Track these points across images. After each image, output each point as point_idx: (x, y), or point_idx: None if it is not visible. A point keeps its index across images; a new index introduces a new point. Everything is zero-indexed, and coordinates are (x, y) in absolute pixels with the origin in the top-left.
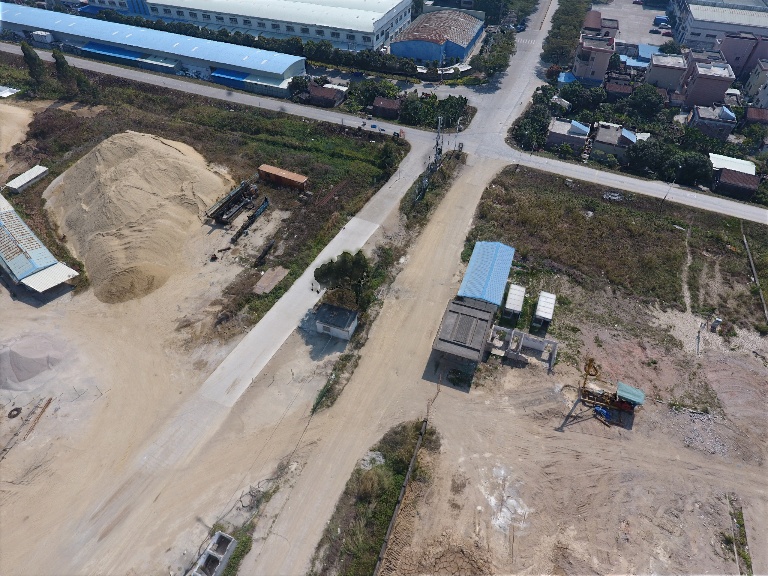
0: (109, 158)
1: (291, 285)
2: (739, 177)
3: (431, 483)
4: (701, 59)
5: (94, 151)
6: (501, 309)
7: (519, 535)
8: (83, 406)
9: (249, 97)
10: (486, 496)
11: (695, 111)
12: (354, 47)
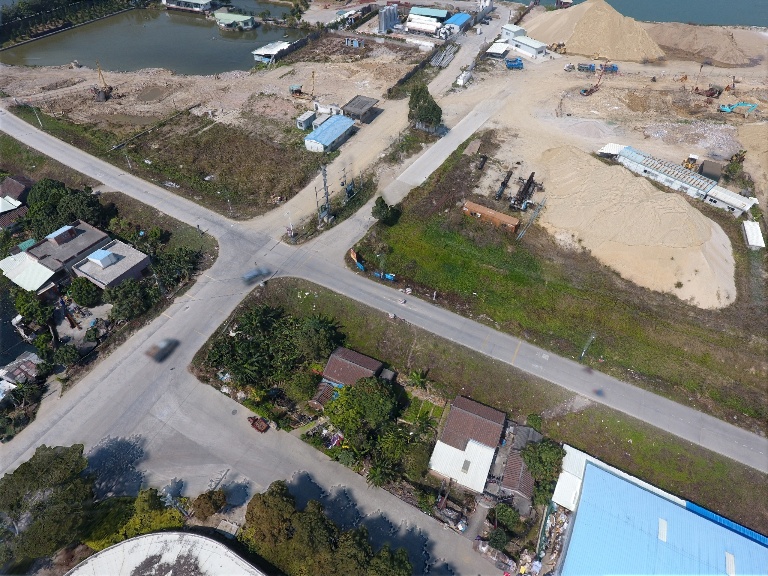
0: None
1: None
2: (25, 182)
3: None
4: None
5: None
6: None
7: None
8: None
9: (622, 404)
10: None
11: None
12: None
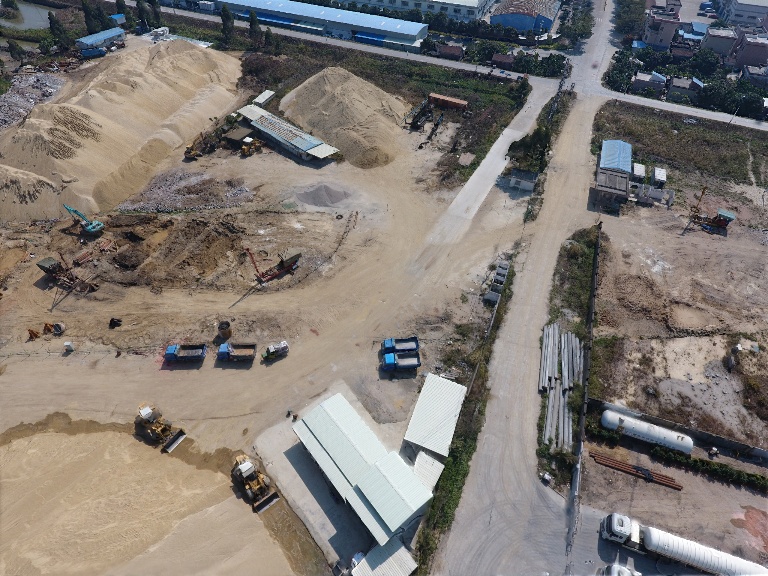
0: (332, 82)
1: (480, 163)
2: None
3: (610, 254)
4: (748, 32)
5: (322, 76)
6: (630, 177)
7: (669, 275)
8: (379, 216)
9: (394, 52)
10: (644, 260)
11: (745, 69)
12: (462, 18)
